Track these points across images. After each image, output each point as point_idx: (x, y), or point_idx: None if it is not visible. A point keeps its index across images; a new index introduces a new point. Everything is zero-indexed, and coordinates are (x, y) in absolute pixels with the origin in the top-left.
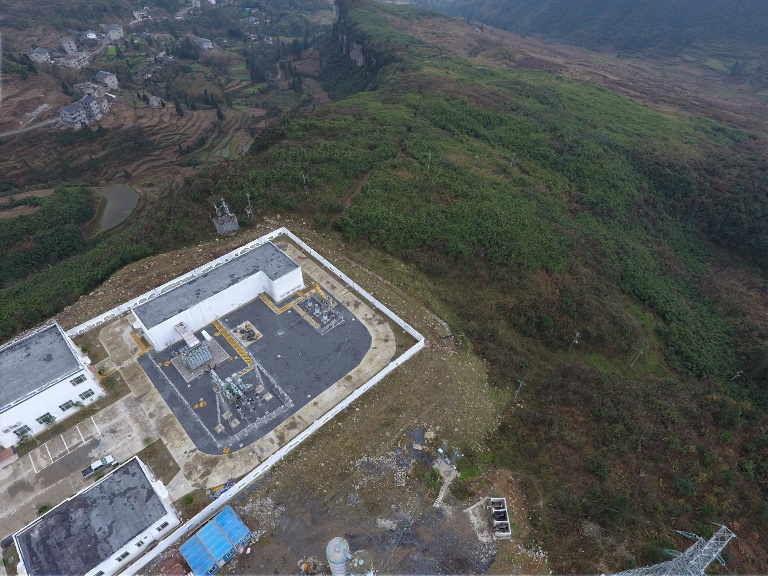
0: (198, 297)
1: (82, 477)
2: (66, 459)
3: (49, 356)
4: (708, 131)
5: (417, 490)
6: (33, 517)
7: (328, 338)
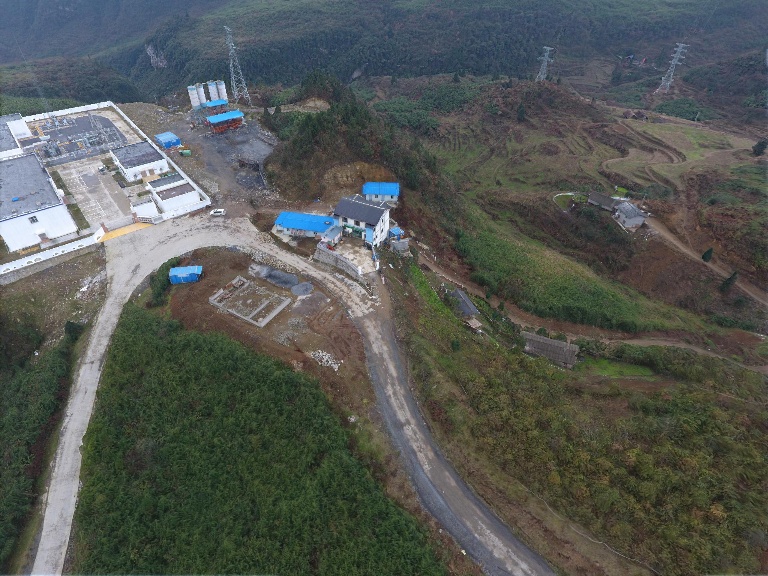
0: (6, 138)
1: (104, 174)
2: (87, 181)
3: (8, 165)
4: (8, 70)
5: (181, 114)
6: (115, 183)
7: (81, 124)
